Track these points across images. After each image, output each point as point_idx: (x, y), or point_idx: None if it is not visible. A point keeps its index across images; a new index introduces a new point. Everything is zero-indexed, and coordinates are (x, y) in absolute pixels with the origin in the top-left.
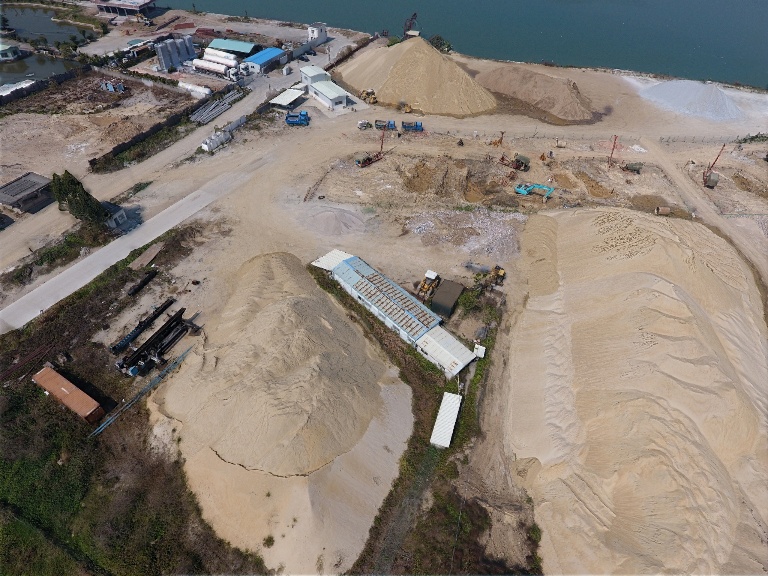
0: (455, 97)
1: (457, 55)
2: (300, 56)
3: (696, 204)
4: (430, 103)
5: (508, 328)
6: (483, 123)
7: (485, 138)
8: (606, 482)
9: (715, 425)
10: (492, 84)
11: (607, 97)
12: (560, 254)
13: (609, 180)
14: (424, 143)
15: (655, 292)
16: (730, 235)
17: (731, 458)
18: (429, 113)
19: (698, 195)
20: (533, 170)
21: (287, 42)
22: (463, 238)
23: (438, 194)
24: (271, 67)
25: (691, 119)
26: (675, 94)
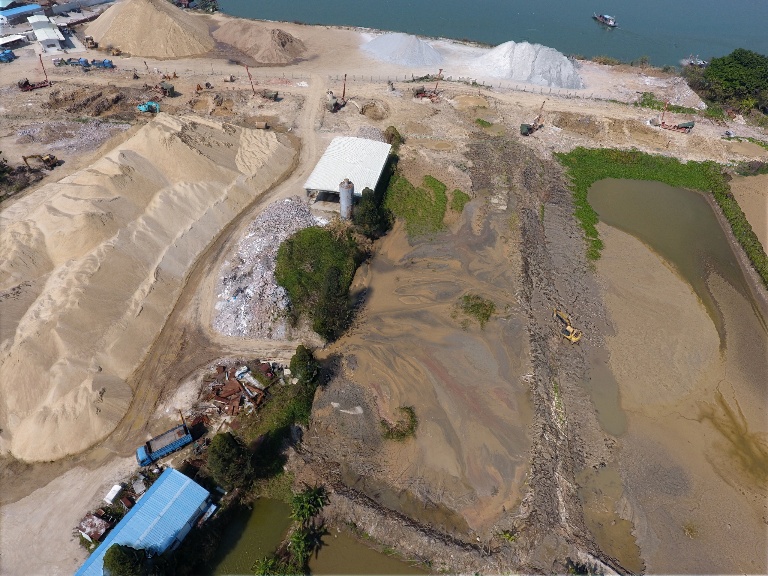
0: (162, 42)
1: (219, 15)
2: None
3: (303, 122)
4: (138, 47)
5: (22, 196)
6: (178, 64)
7: (166, 74)
8: None
9: (57, 238)
10: (221, 36)
11: (326, 48)
12: None
13: (243, 105)
14: (103, 76)
15: None
16: (305, 143)
17: (62, 261)
18: (136, 56)
19: (314, 117)
20: (181, 97)
21: (64, 2)
22: (55, 139)
23: (72, 111)
24: (21, 20)
25: (385, 65)
26: (385, 45)
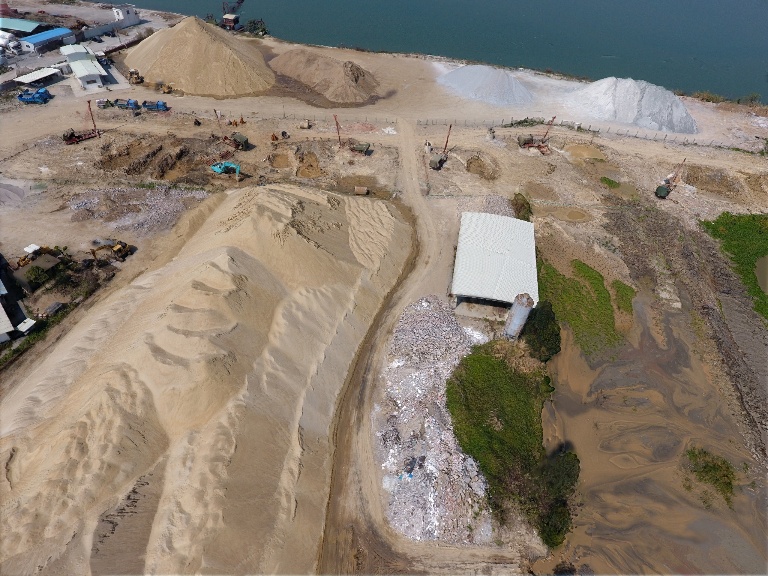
0: (219, 78)
1: (270, 39)
2: (93, 37)
3: (406, 185)
4: (192, 84)
5: (93, 303)
6: (241, 104)
7: (230, 118)
8: (28, 456)
9: (171, 397)
10: (280, 67)
11: (399, 81)
12: (199, 230)
13: (330, 160)
14: (158, 122)
15: (207, 264)
16: (418, 215)
17: (179, 432)
18: (190, 94)
19: (417, 176)
20: (256, 150)
21: (94, 24)
22: (119, 214)
23: (131, 172)
24: (50, 47)
25: (473, 104)
26: (467, 79)
